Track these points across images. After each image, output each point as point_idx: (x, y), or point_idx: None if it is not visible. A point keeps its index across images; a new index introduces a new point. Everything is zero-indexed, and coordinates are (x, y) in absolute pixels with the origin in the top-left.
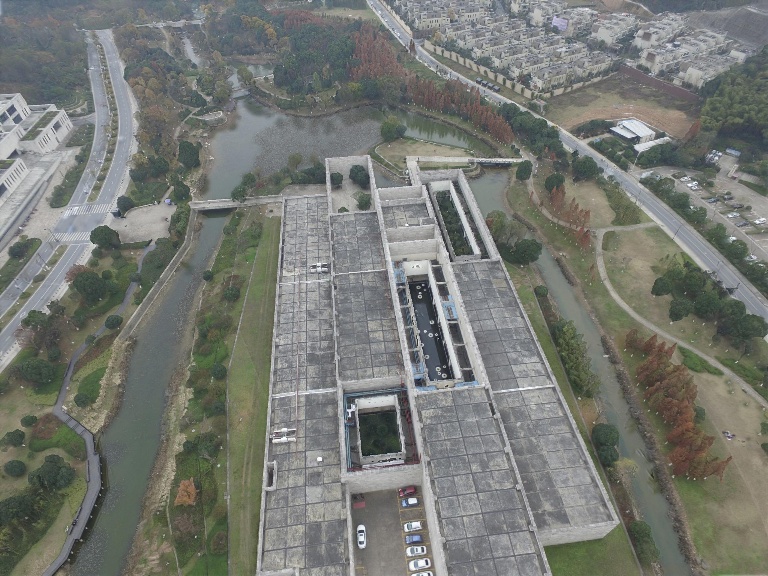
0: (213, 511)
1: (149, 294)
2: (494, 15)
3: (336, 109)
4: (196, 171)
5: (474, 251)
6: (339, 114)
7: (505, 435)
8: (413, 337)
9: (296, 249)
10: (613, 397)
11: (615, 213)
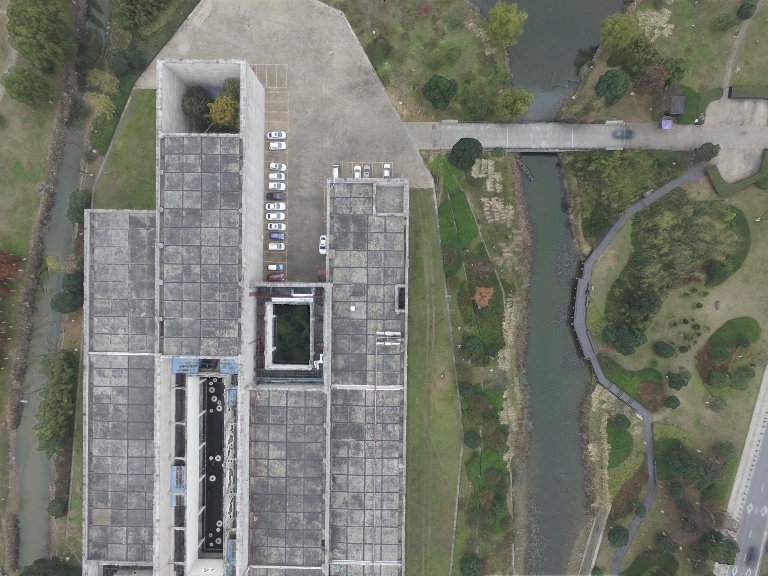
0: (459, 283)
1: None
2: None
3: None
4: None
5: None
6: None
7: (157, 297)
8: (236, 450)
9: None
10: (42, 350)
11: None
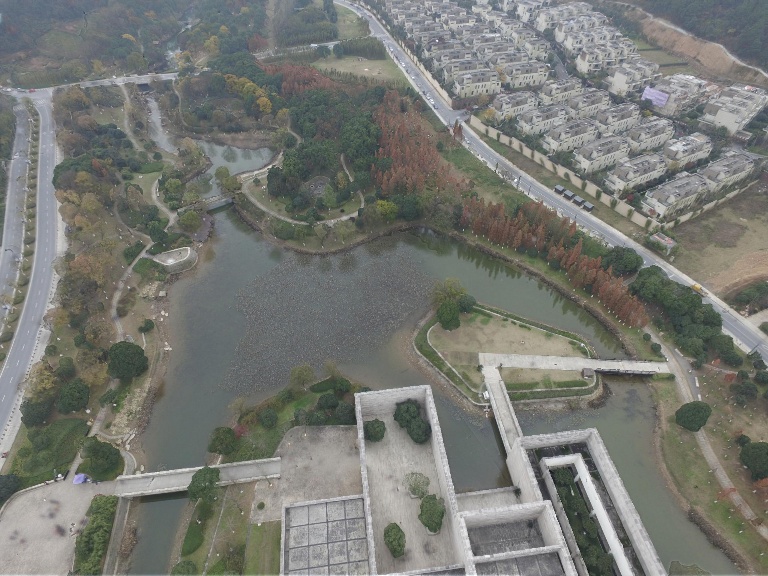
0: None
1: None
2: (562, 81)
3: (358, 239)
4: (139, 385)
5: None
6: (363, 249)
7: None
8: None
9: None
10: None
11: None
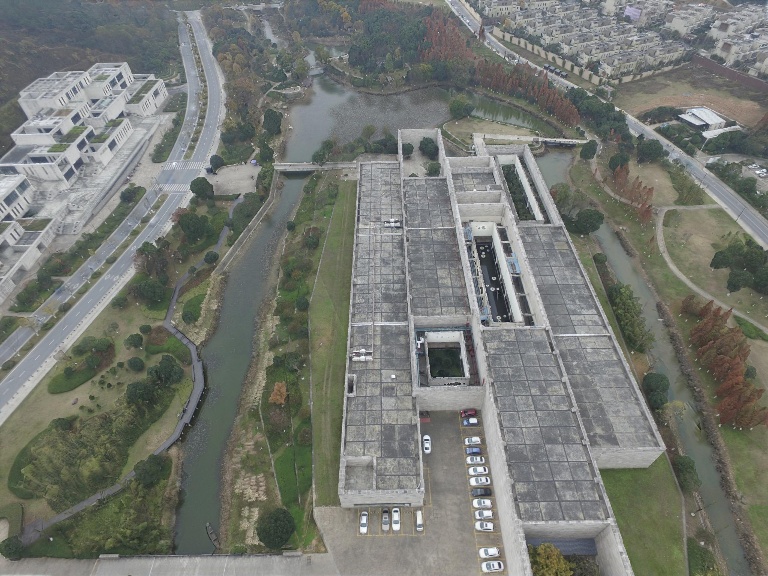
0: (299, 412)
1: (240, 238)
2: (565, 4)
3: (406, 88)
4: (277, 138)
5: (537, 219)
6: (409, 93)
7: (563, 368)
8: (477, 287)
9: (371, 206)
10: (665, 355)
11: (678, 194)
